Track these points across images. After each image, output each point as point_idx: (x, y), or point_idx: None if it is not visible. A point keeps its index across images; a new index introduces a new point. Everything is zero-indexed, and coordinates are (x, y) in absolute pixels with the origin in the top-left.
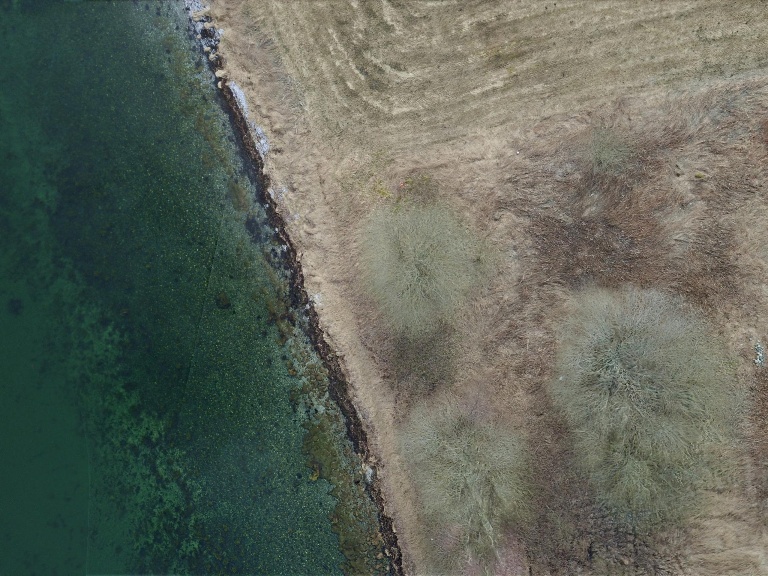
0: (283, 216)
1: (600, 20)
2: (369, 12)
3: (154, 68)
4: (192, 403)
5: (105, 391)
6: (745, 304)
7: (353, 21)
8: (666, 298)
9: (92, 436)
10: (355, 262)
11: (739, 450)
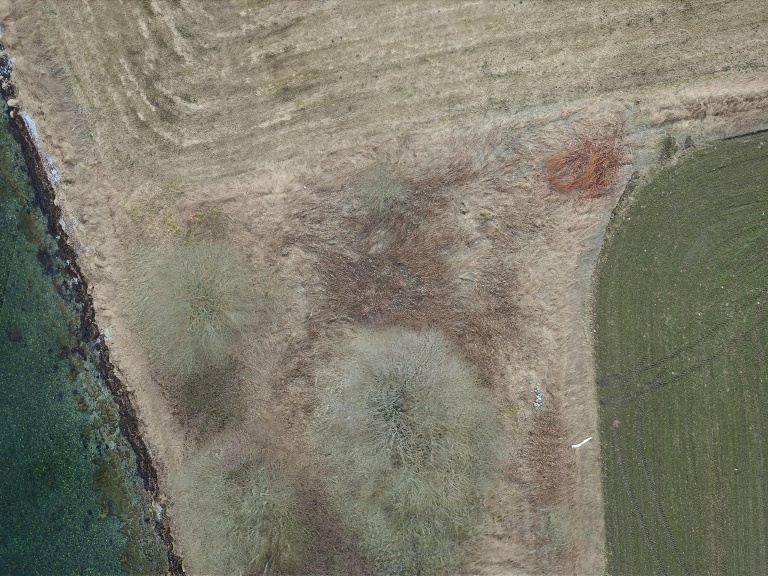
0: (74, 248)
1: (386, 54)
2: (160, 42)
3: None
4: None
5: None
6: (526, 346)
7: (144, 51)
8: (452, 338)
9: None
10: (145, 296)
11: (518, 495)
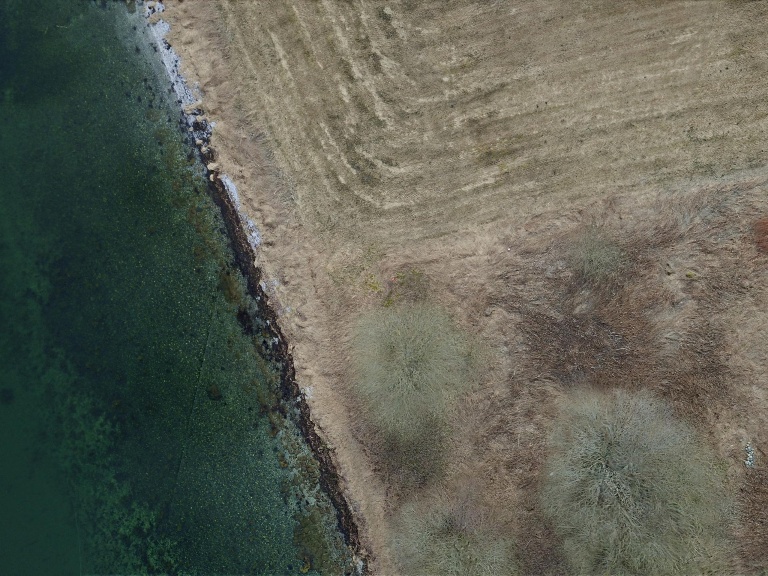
0: (275, 309)
1: (591, 119)
2: (361, 107)
3: (146, 160)
4: (183, 494)
5: (96, 481)
6: (735, 405)
7: (345, 116)
8: (657, 396)
9: (83, 526)
10: (346, 356)
11: (729, 551)
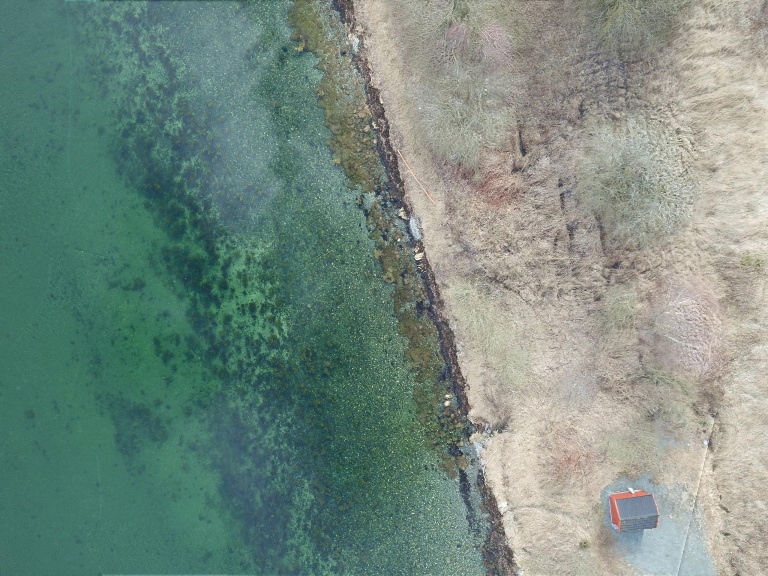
0: None
1: None
2: None
3: None
4: None
5: None
6: None
7: None
8: None
9: (74, 13)
10: None
11: None
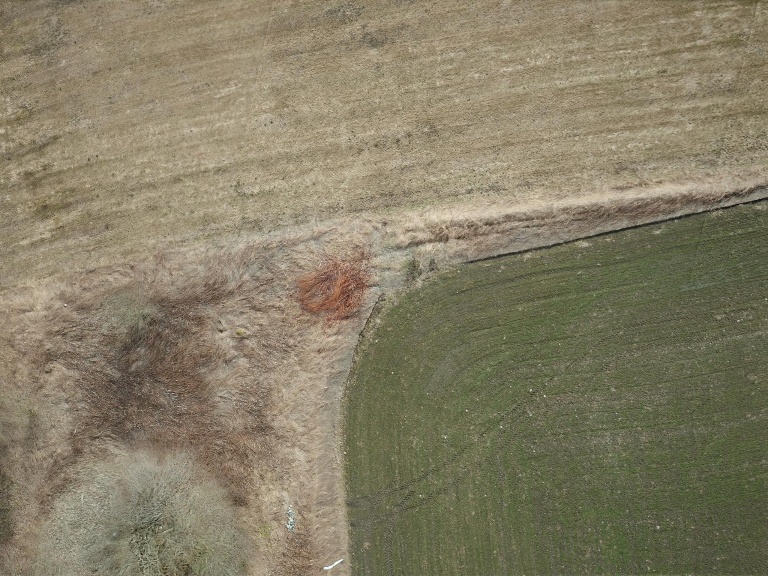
0: None
1: (140, 173)
2: None
3: None
4: None
5: None
6: (278, 467)
7: None
8: (213, 456)
9: None
10: None
11: None
